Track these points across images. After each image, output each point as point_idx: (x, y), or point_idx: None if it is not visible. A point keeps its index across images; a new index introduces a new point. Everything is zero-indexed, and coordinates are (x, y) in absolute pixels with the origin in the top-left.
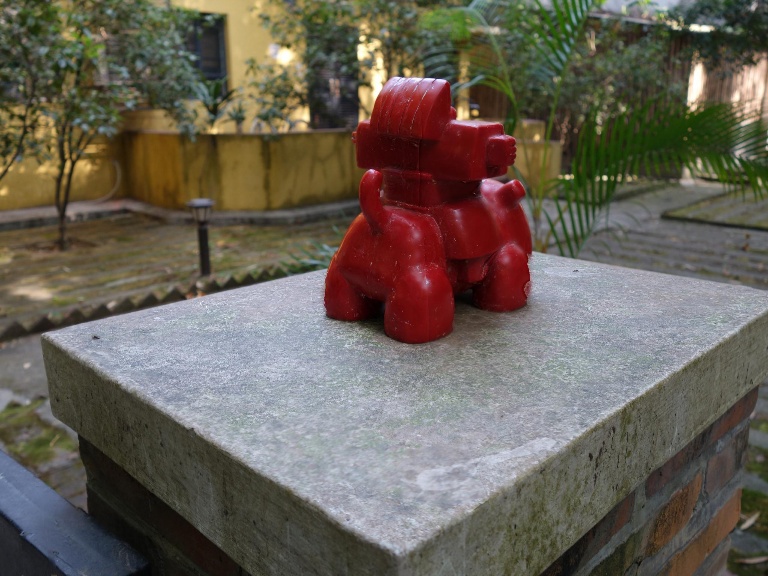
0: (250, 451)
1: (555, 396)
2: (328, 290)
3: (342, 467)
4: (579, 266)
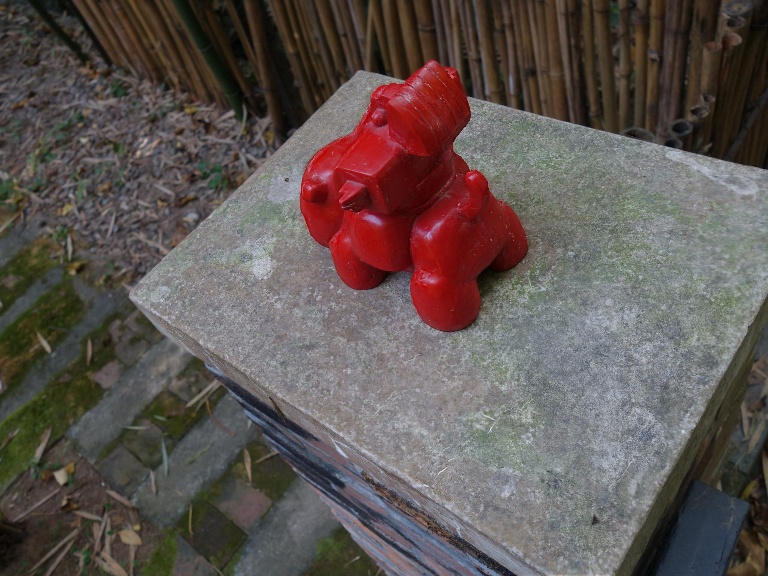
0: (764, 278)
1: (601, 159)
2: (453, 314)
3: (757, 228)
4: (269, 179)
